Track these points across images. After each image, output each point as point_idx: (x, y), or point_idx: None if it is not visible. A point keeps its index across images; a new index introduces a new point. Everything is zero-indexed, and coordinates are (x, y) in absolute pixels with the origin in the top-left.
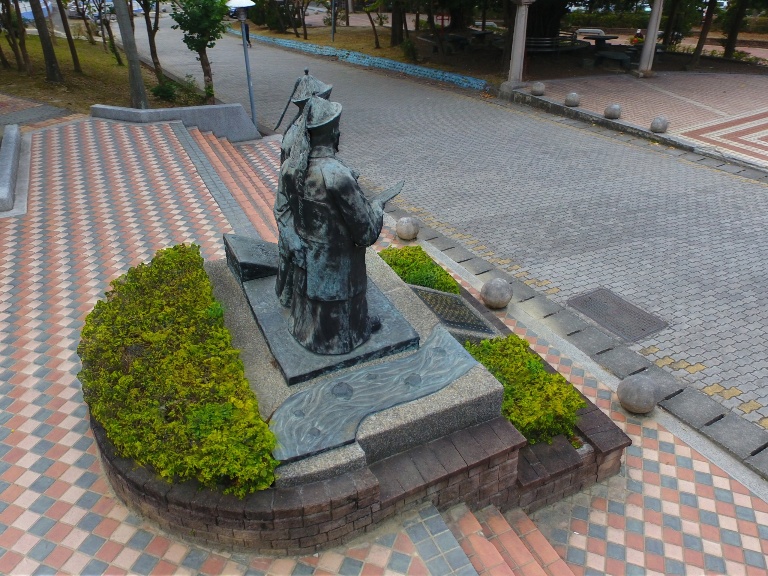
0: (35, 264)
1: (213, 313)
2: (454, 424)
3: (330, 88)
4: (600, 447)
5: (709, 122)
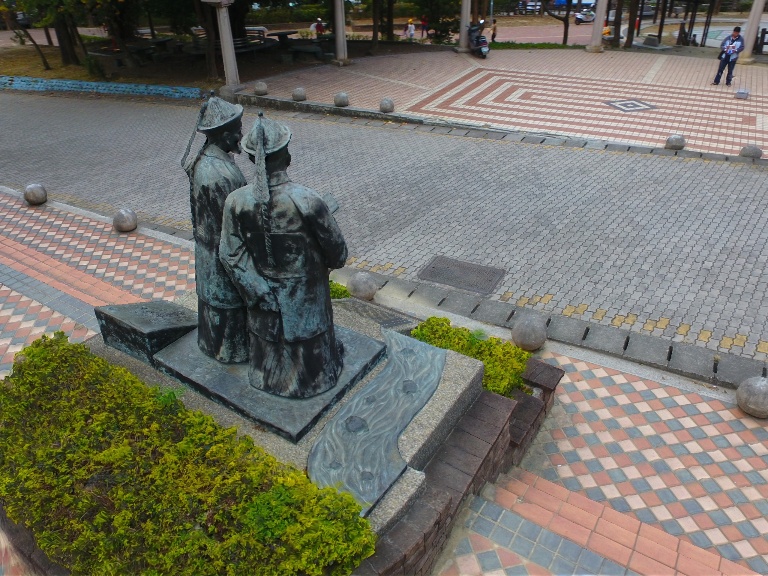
0: None
1: (167, 399)
2: (459, 413)
3: None
4: (548, 386)
5: (420, 97)
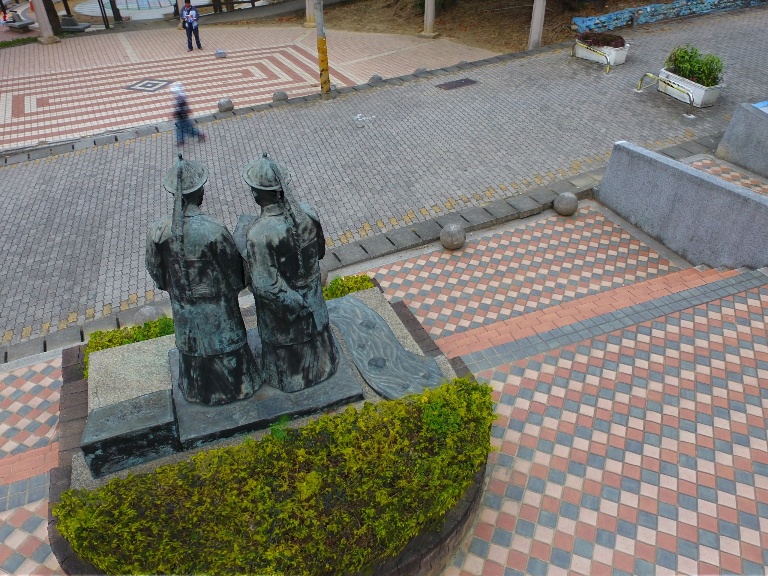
0: None
1: (282, 433)
2: None
3: None
4: None
5: None
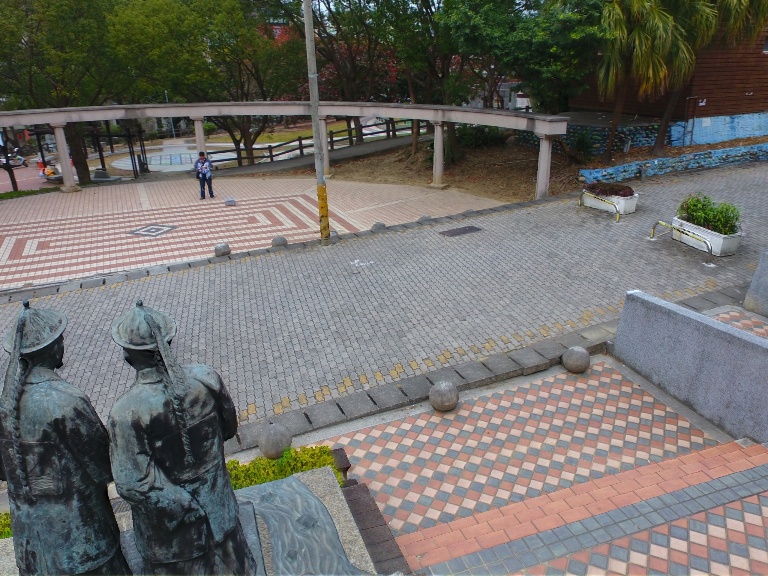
0: None
1: None
2: None
3: (57, 311)
4: (346, 466)
5: None
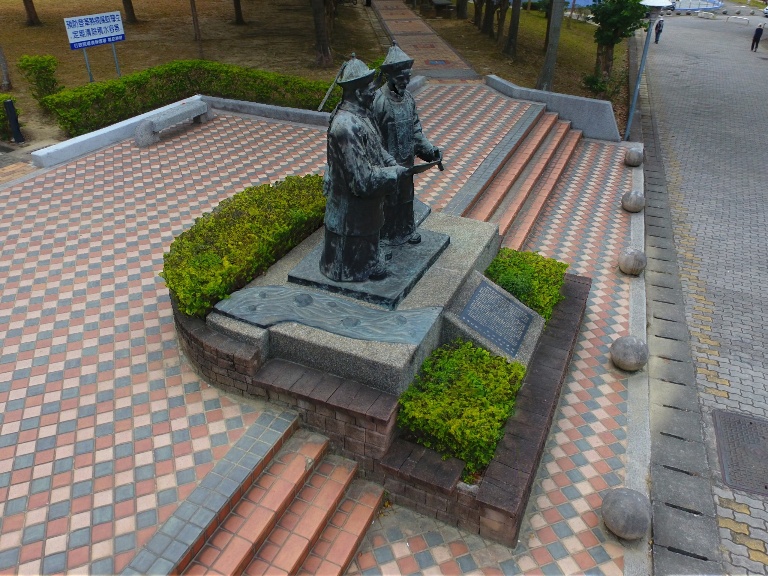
0: (320, 165)
1: None
2: (352, 372)
3: (405, 61)
4: (478, 494)
5: None
